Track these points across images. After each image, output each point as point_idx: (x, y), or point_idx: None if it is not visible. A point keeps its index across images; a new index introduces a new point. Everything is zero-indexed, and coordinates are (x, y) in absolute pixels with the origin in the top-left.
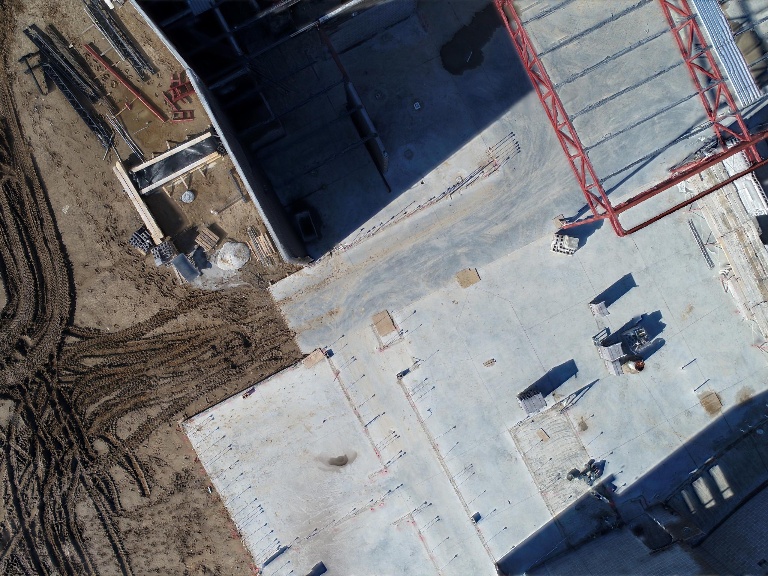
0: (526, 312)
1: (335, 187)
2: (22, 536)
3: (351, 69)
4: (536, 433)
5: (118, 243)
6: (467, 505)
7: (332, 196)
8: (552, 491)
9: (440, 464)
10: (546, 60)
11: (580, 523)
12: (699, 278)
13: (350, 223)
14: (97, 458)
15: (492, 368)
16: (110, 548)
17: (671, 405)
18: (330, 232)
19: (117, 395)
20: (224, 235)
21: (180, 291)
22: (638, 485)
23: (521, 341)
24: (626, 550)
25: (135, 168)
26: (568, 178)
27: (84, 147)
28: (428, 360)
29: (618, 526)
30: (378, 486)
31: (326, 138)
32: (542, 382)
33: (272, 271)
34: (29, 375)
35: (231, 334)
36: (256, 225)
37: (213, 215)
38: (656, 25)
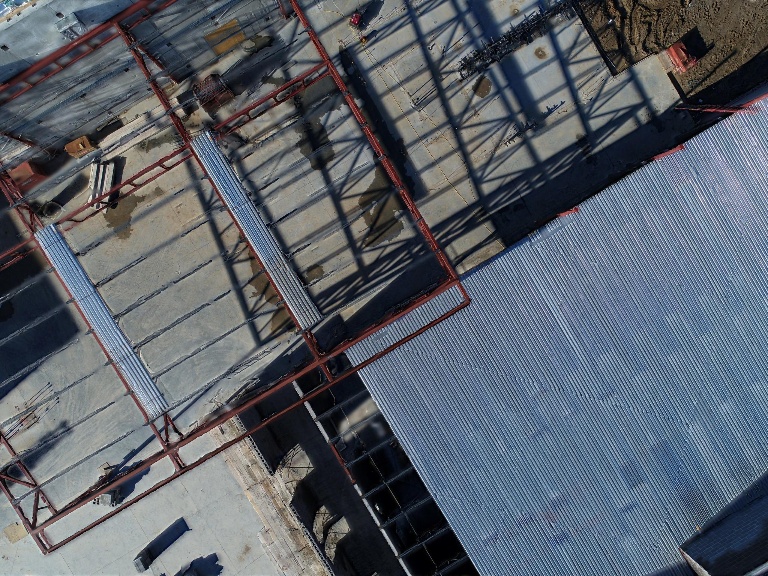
0: (78, 563)
1: None
2: None
3: None
4: None
5: None
6: None
7: None
8: None
9: None
10: None
11: None
12: (253, 518)
13: None
14: None
15: None
16: None
17: None
18: None
19: None
20: None
21: None
22: None
23: None
24: None
25: None
26: (110, 426)
27: None
28: None
29: None
30: None
31: None
32: None
33: None
34: None
35: None
36: None
37: None
38: (187, 266)
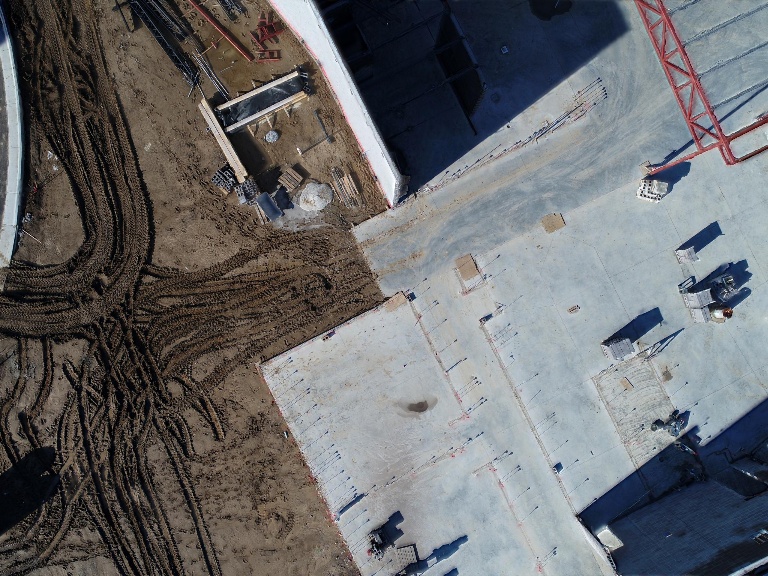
0: (611, 259)
1: (421, 129)
2: (91, 480)
3: (439, 12)
4: (620, 382)
5: (200, 182)
6: (549, 455)
7: (417, 138)
8: (635, 442)
9: (522, 412)
10: (634, 7)
11: (664, 476)
12: None
13: (435, 165)
14: (171, 400)
15: (576, 315)
16: (181, 494)
17: (757, 356)
18: (415, 174)
19: (194, 336)
20: (307, 176)
21: (261, 231)
22: (723, 437)
23: (606, 288)
24: (718, 499)
25: (220, 106)
26: (655, 125)
27: (169, 85)
28: (511, 305)
29: (705, 478)
30: (458, 434)
31: (413, 80)
32: (626, 330)
33: (355, 213)
34: (104, 314)
35: (312, 276)
36: (340, 166)
37: (296, 155)
38: None
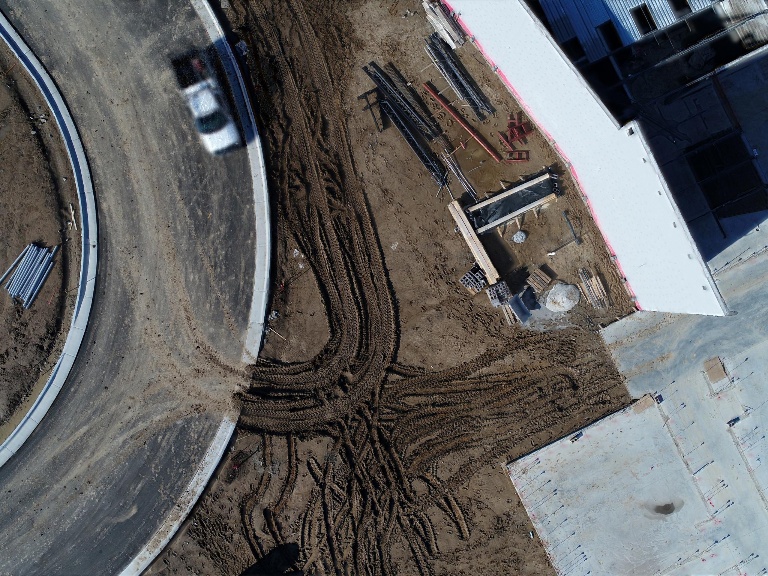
0: None
1: None
2: None
3: None
4: None
5: (446, 281)
6: None
7: None
8: None
9: None
10: None
11: None
12: None
13: None
14: (416, 499)
15: None
16: None
17: None
18: None
19: (439, 435)
20: (554, 276)
21: (508, 331)
22: None
23: None
24: None
25: (472, 207)
26: None
27: (417, 184)
28: (759, 409)
29: None
30: (704, 536)
31: None
32: None
33: (602, 314)
34: (349, 412)
35: (558, 376)
36: (587, 267)
37: (544, 256)
38: None
